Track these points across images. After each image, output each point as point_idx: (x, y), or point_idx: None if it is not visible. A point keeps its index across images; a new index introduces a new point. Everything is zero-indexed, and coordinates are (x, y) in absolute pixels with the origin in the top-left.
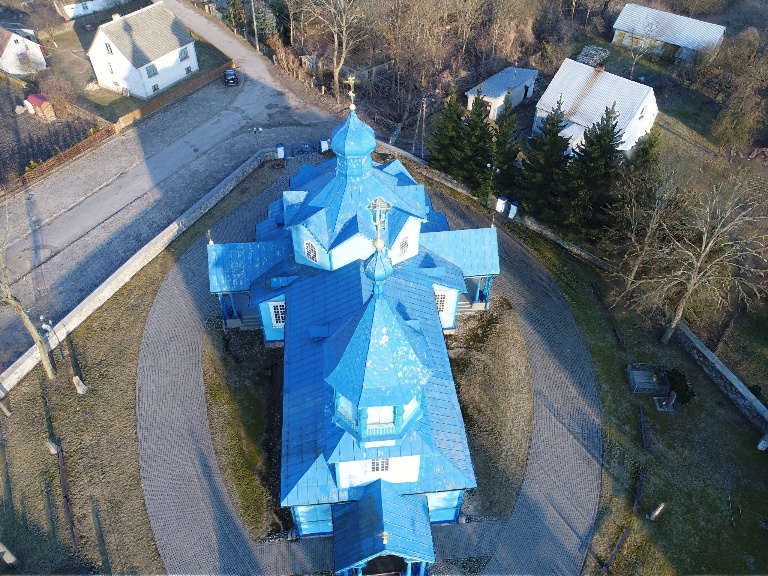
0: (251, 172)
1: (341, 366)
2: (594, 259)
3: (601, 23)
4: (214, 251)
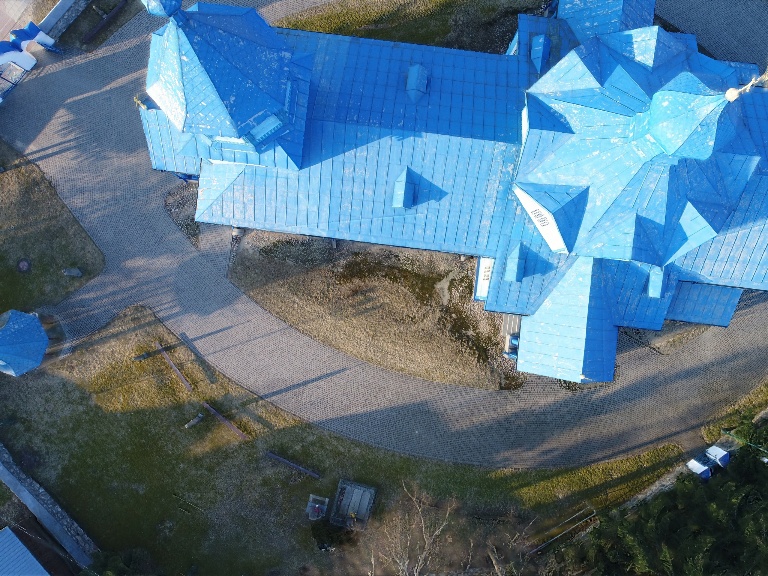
0: None
1: None
2: None
3: None
4: None
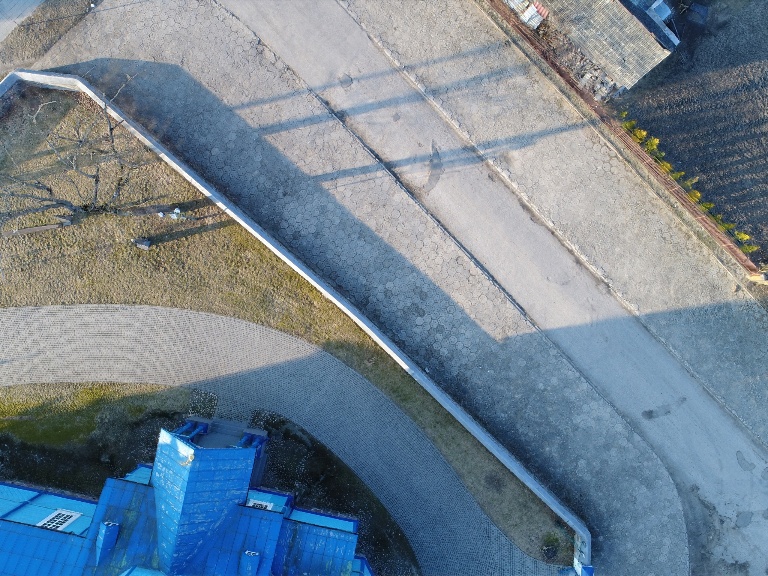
0: None
1: None
2: None
3: None
4: (187, 456)
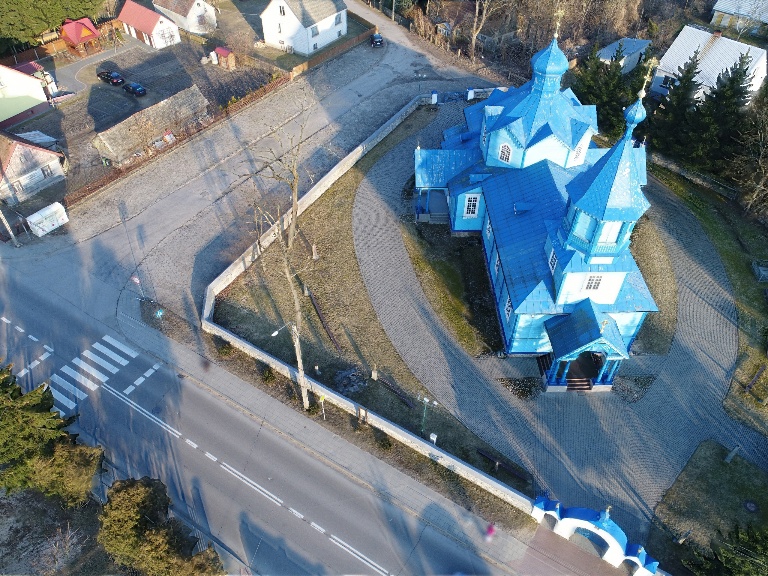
0: (411, 113)
1: (588, 194)
2: (715, 188)
3: (702, 5)
4: (420, 155)
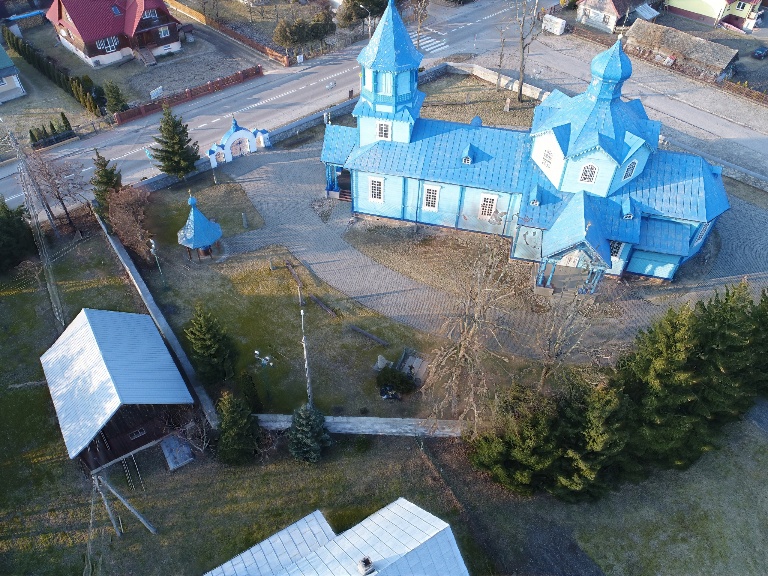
0: (766, 191)
1: None
2: None
3: None
4: None
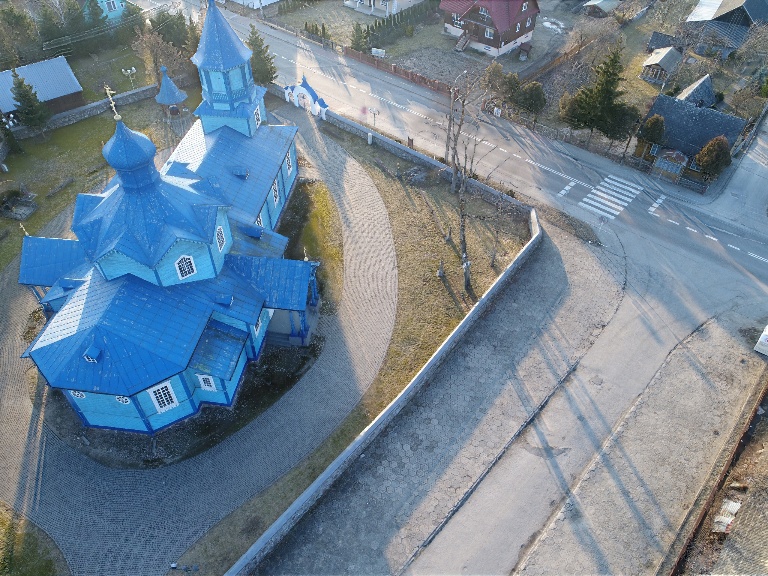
0: None
1: None
2: None
3: None
4: None
